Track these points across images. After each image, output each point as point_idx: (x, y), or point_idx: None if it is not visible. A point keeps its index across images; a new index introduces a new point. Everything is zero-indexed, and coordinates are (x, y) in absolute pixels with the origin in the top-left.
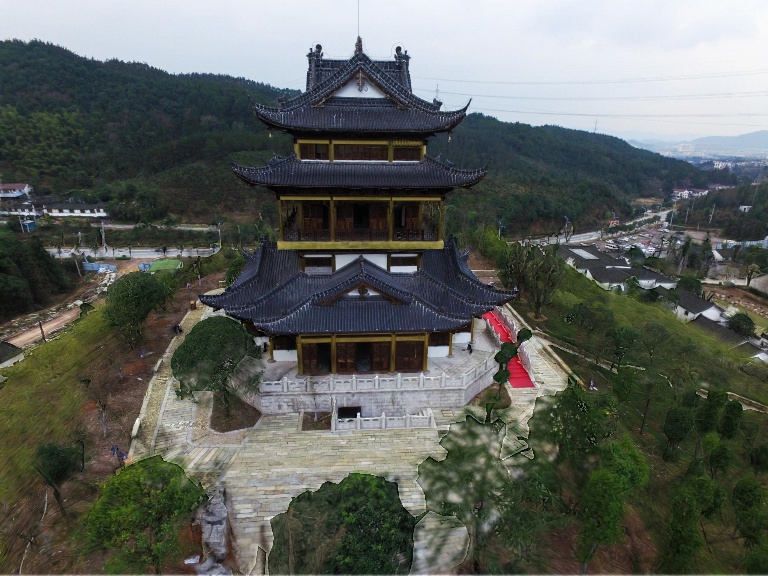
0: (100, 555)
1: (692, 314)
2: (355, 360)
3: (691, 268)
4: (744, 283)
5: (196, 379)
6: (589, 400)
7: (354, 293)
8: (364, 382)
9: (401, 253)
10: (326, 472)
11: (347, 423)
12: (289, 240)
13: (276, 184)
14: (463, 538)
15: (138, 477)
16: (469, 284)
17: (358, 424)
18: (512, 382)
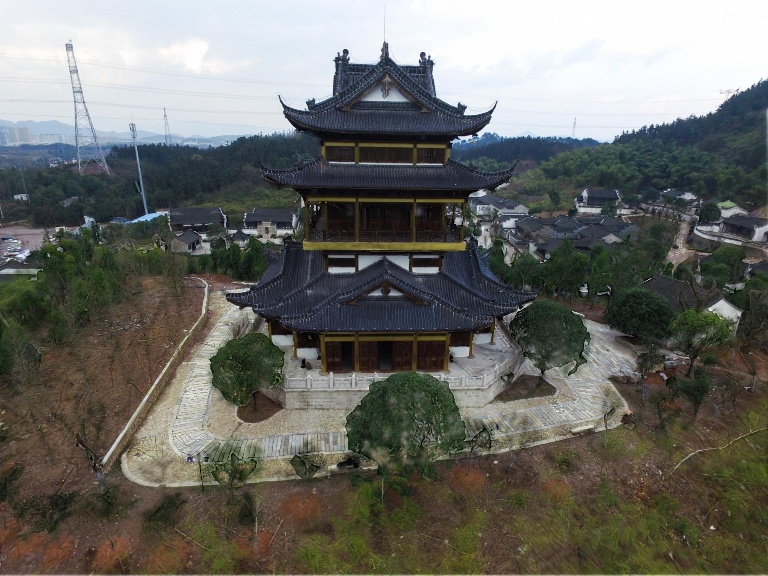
0: (690, 410)
1: None
2: None
3: None
4: None
5: None
6: None
7: None
8: None
9: None
10: None
11: None
12: None
13: None
14: None
15: (705, 312)
16: None
17: None
18: None
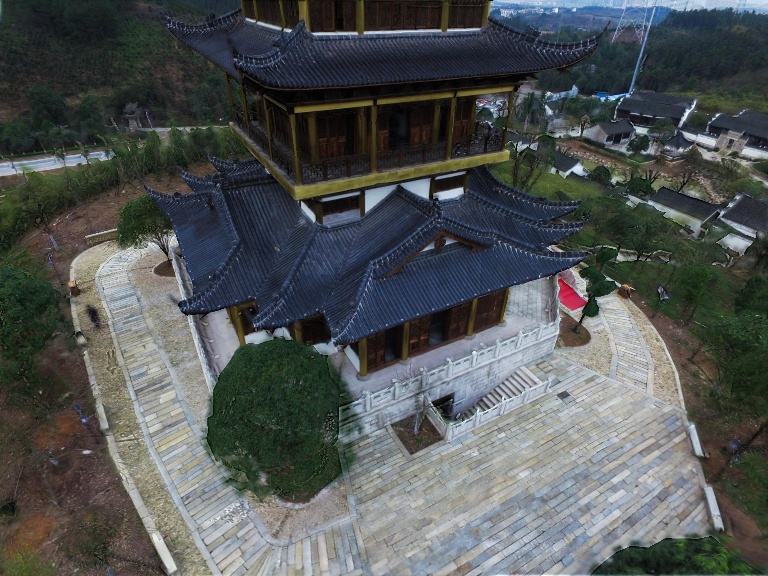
0: None
1: (563, 172)
2: (429, 334)
3: (533, 124)
4: (576, 134)
5: (289, 465)
6: (765, 333)
7: (427, 248)
8: (460, 363)
9: (449, 173)
10: (494, 508)
11: (464, 425)
12: (311, 181)
13: (306, 86)
14: (700, 533)
15: None
16: (512, 198)
17: (477, 421)
18: (566, 304)
